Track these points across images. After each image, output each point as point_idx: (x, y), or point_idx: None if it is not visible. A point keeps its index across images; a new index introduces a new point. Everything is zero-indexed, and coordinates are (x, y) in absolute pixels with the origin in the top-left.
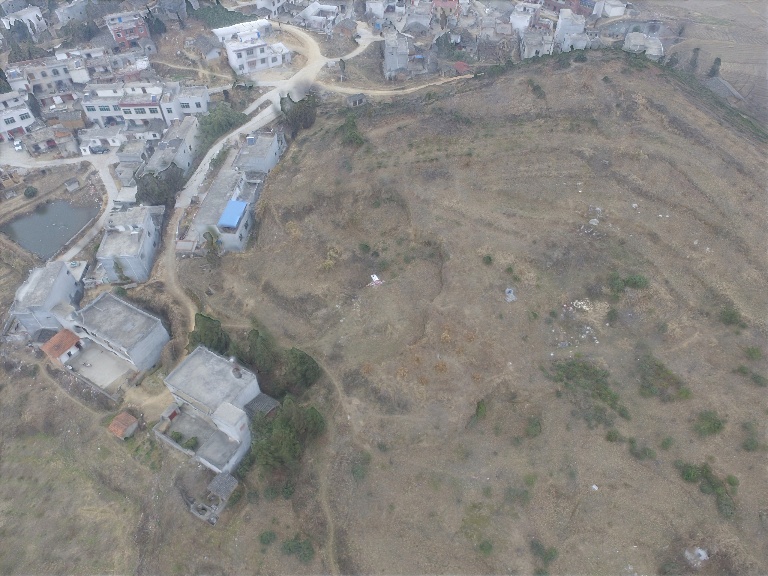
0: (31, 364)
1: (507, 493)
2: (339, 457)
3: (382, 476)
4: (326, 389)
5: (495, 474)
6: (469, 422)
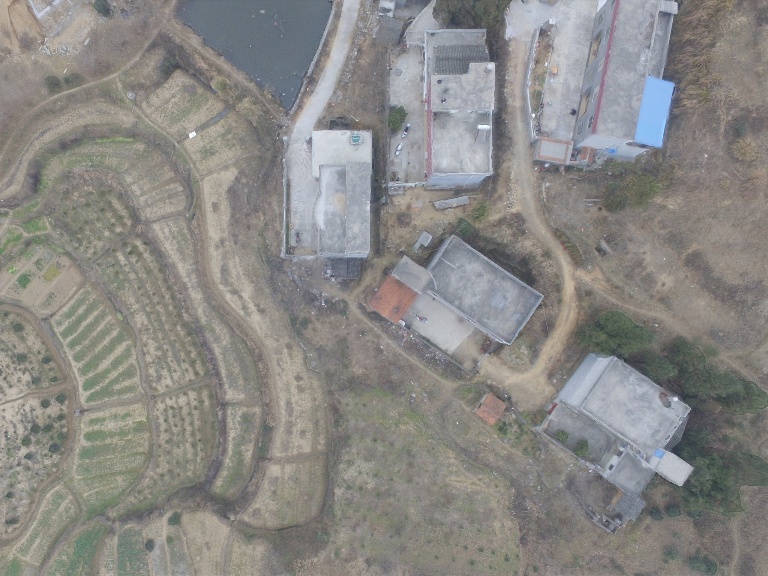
0: (336, 298)
1: None
2: (763, 495)
3: None
4: None
5: None
6: None
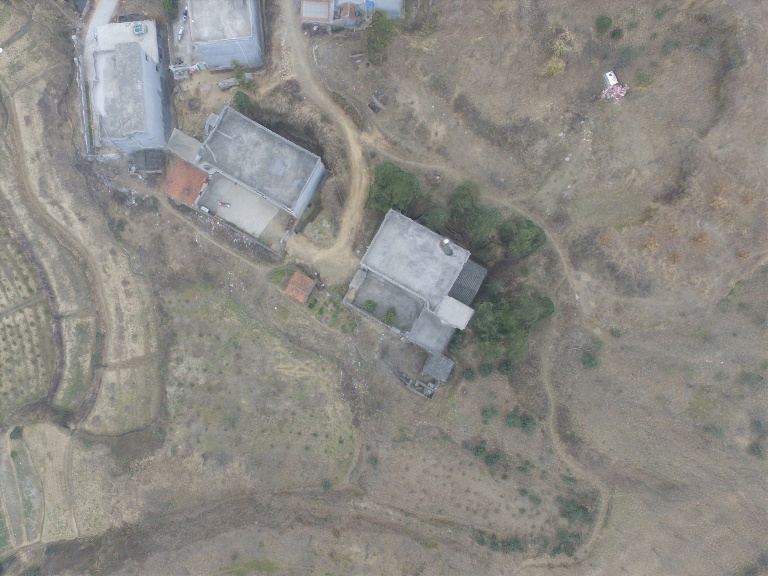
0: (146, 196)
1: (738, 376)
2: (565, 341)
3: (610, 360)
4: (546, 257)
5: (730, 358)
6: (716, 304)
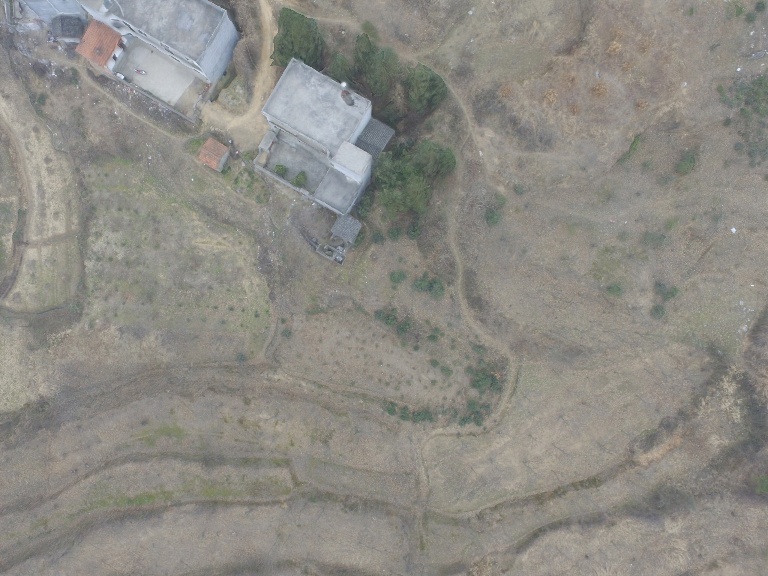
0: (66, 67)
1: (642, 237)
2: (470, 199)
3: (515, 220)
4: (451, 115)
5: (634, 218)
6: (618, 160)
